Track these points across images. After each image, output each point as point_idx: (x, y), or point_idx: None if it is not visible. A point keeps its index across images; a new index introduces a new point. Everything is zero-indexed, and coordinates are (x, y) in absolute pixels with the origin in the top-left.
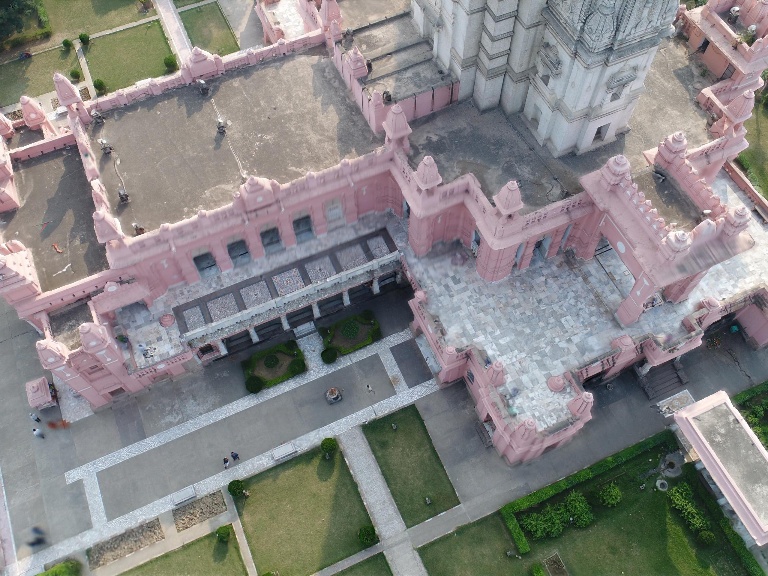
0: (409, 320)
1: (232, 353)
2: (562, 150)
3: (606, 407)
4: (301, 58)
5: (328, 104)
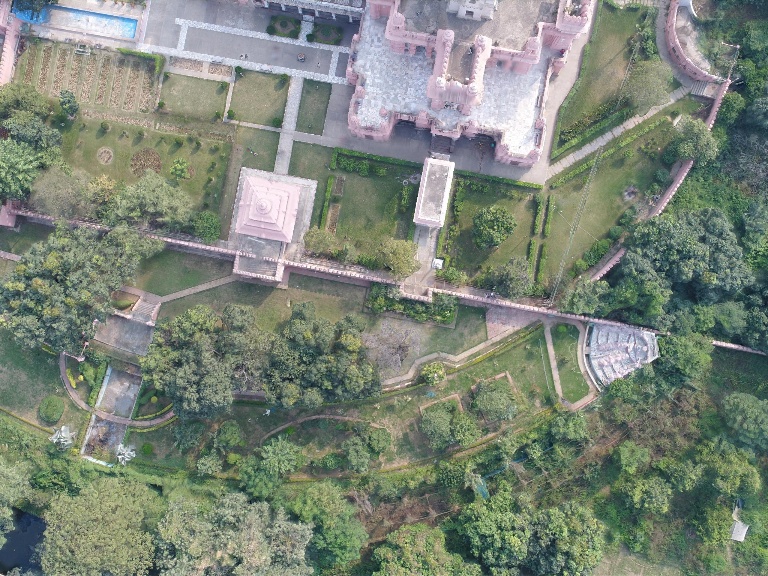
0: None
1: (271, 8)
2: (450, 10)
3: (410, 139)
4: None
5: None
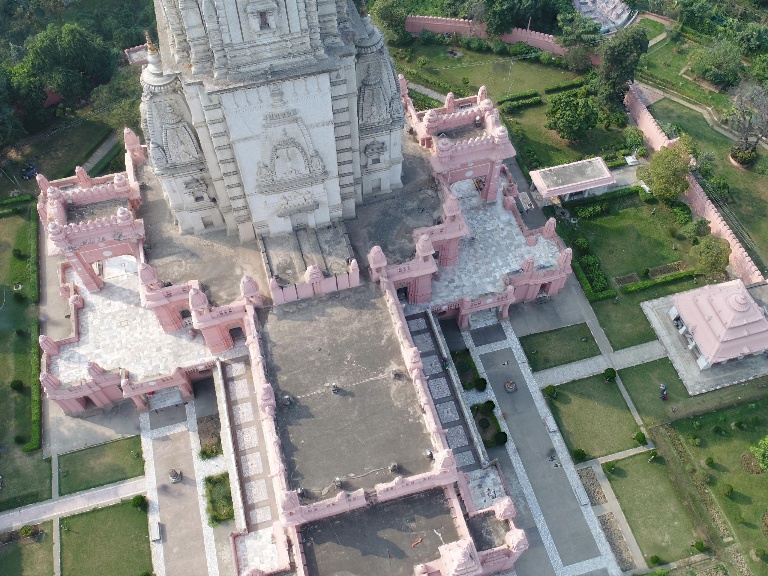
0: (456, 331)
1: None
2: None
3: None
4: (268, 327)
5: (324, 312)
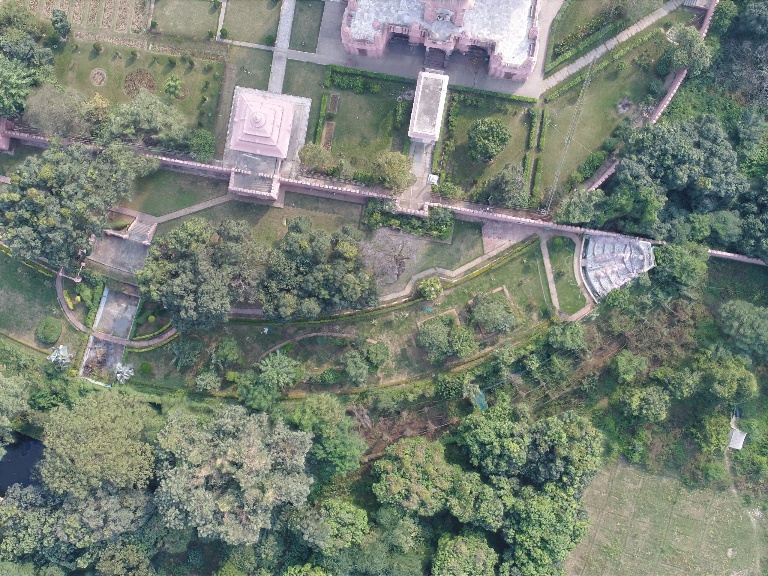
0: None
1: None
2: None
3: (403, 55)
4: None
5: None
